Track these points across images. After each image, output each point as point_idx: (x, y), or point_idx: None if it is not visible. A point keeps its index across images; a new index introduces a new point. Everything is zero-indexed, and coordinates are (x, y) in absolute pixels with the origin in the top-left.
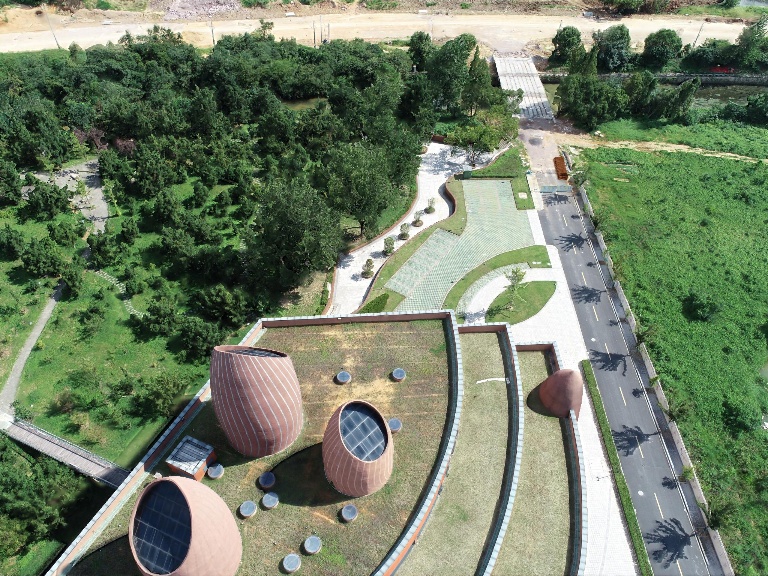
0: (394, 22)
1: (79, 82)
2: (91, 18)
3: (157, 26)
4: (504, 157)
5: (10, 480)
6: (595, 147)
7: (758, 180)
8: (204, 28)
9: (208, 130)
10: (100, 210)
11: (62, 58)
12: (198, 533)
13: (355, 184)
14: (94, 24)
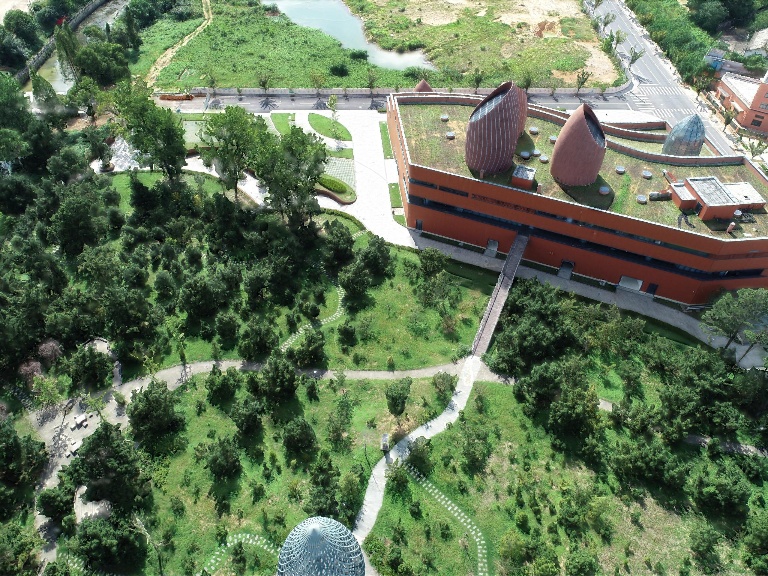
0: None
1: None
2: None
3: None
4: None
5: None
6: (153, 81)
7: (223, 33)
8: None
9: None
10: (166, 376)
11: None
12: None
13: None
14: None
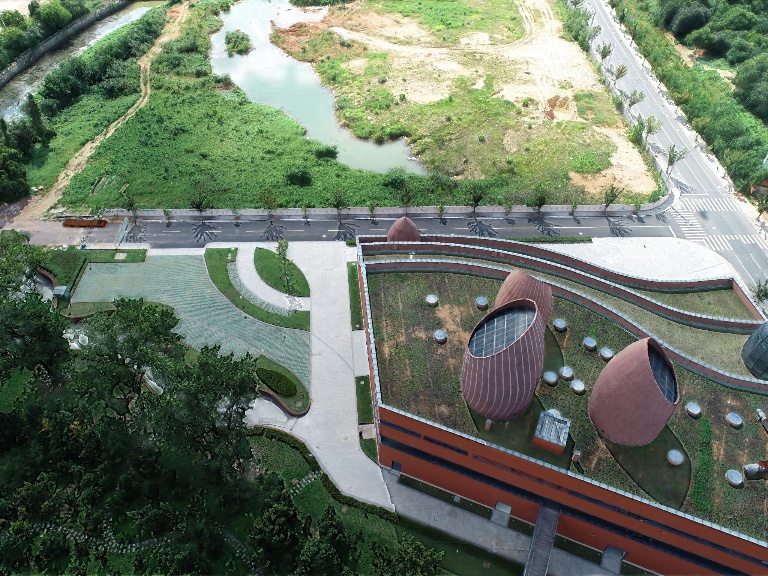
0: None
1: None
2: None
3: None
4: (44, 262)
5: None
6: (59, 195)
7: (159, 119)
8: None
9: None
10: None
11: None
12: None
13: None
14: None
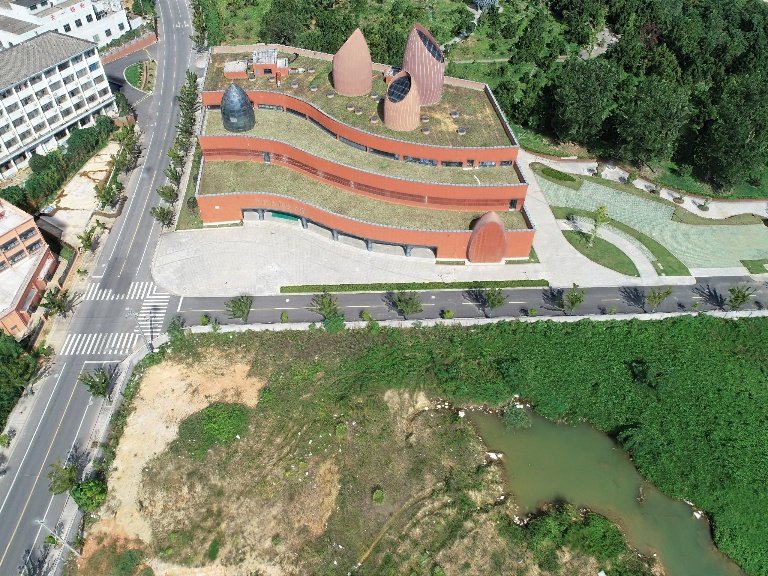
0: None
1: None
2: None
3: None
4: None
5: None
6: None
7: None
8: None
9: None
10: None
11: None
12: (343, 49)
13: None
14: None
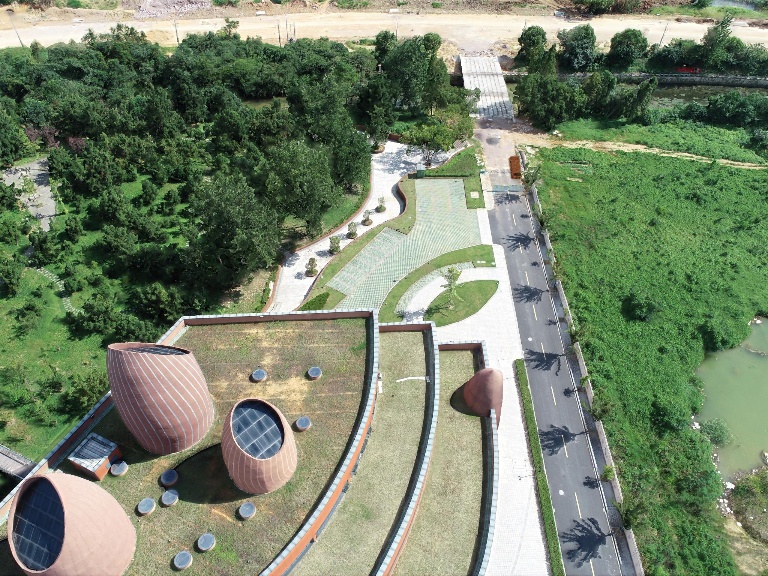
0: (364, 21)
1: (40, 80)
2: (61, 16)
3: (121, 24)
4: (459, 156)
5: None
6: (552, 147)
7: (711, 180)
8: (173, 27)
9: (161, 128)
10: (48, 208)
11: (25, 56)
12: (72, 529)
13: (297, 183)
14: (64, 22)
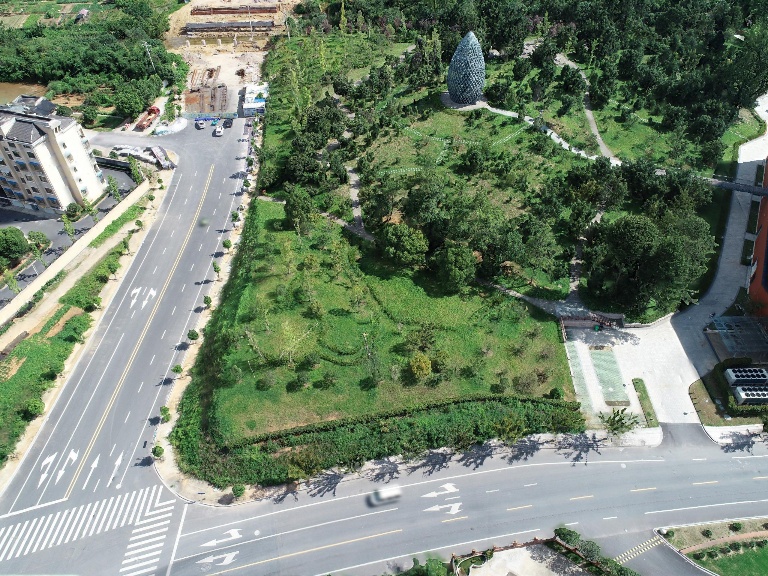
0: None
1: None
2: None
3: None
4: None
5: (680, 174)
6: None
7: None
8: None
9: (622, 19)
10: (571, 66)
11: None
12: None
13: None
14: None
